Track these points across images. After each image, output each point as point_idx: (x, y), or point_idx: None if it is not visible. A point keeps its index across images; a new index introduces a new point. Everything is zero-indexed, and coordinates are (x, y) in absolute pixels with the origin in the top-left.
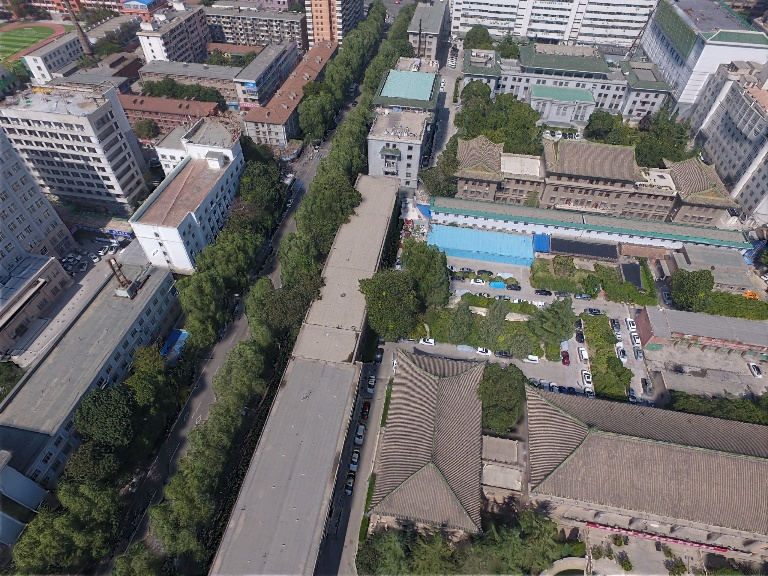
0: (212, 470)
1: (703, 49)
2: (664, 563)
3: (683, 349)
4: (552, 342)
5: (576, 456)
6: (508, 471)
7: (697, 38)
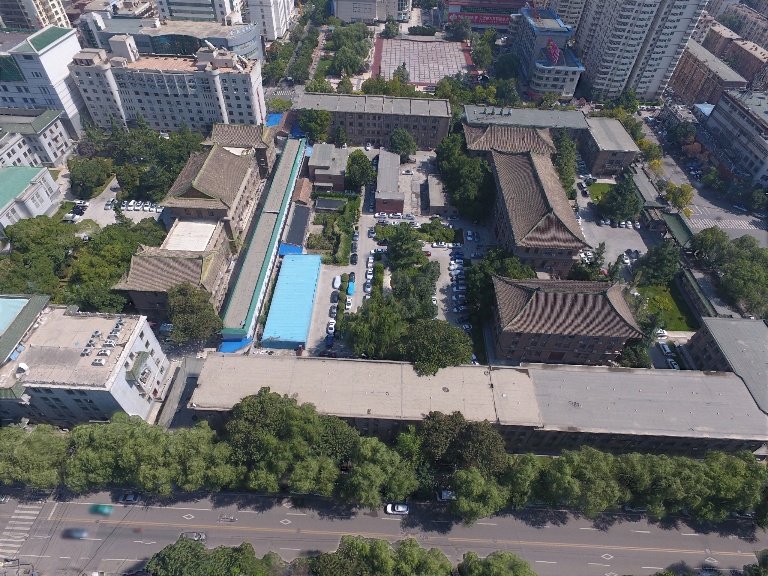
0: None
1: (41, 62)
2: None
3: None
4: None
5: None
6: None
7: (14, 58)
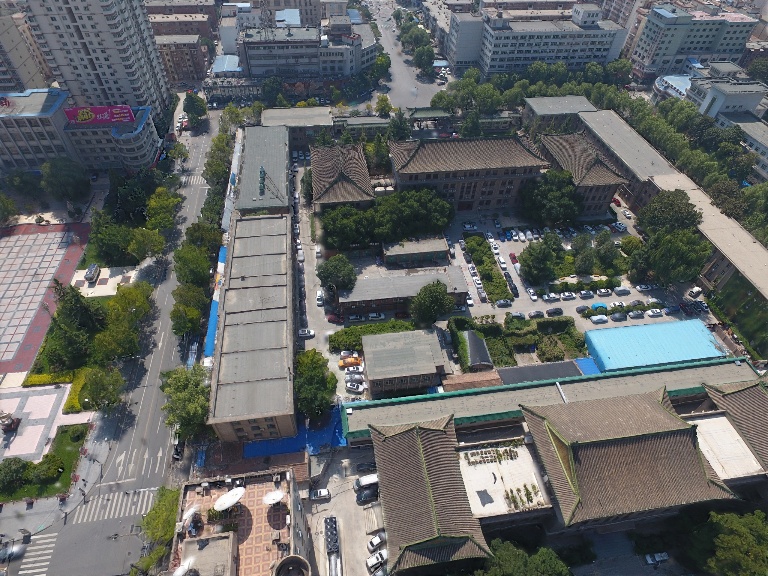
0: None
1: None
2: None
3: None
4: None
5: None
6: None
7: None
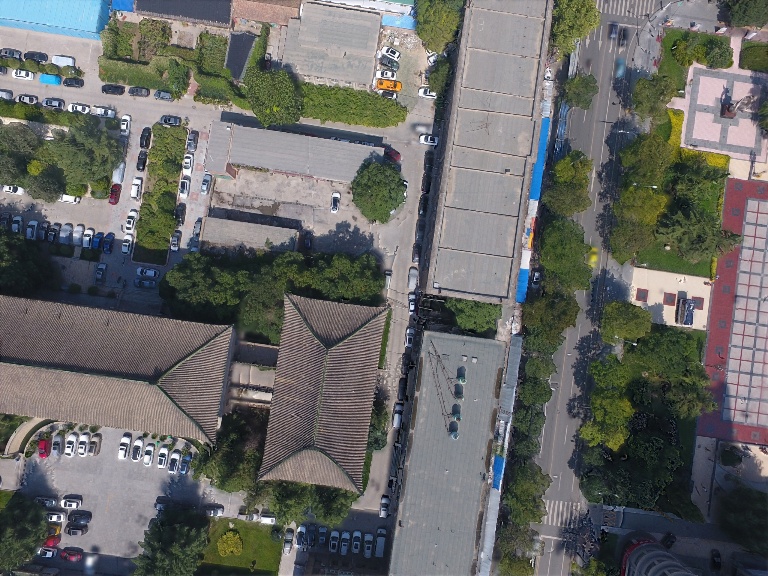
0: None
1: None
2: None
3: (265, 175)
4: (79, 182)
5: None
6: None
7: None
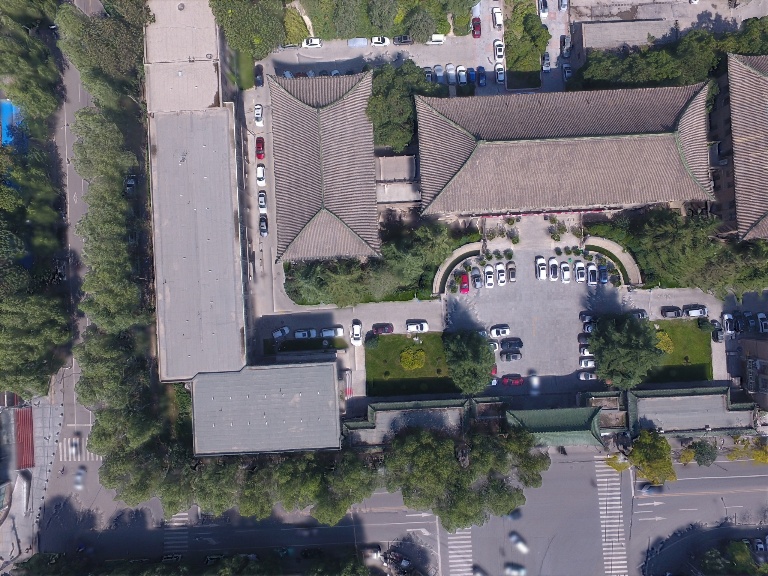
0: (118, 258)
1: None
2: (549, 229)
3: None
4: (458, 12)
5: (464, 171)
6: (409, 184)
7: None
